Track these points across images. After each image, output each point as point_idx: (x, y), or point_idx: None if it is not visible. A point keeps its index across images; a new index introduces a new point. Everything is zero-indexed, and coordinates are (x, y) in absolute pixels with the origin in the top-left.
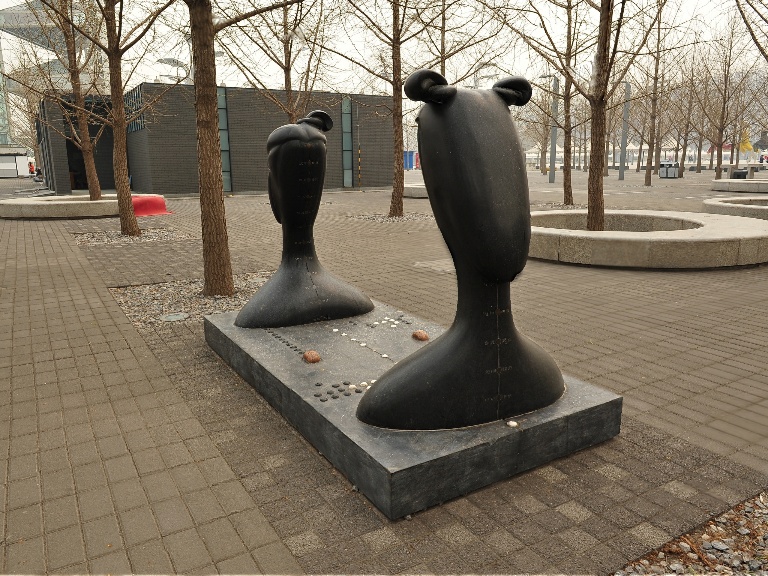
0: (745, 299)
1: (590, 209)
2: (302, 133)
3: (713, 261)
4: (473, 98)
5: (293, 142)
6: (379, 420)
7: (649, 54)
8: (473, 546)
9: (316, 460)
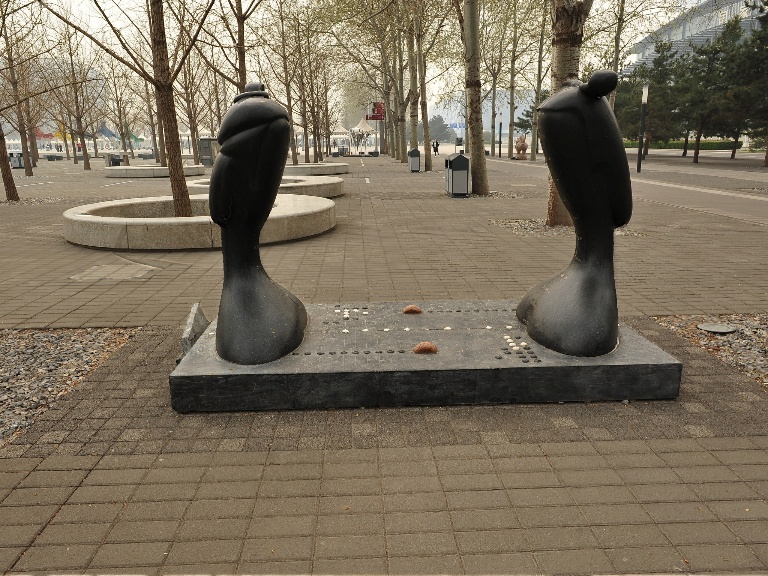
0: None
1: (178, 196)
2: (282, 110)
3: (321, 227)
4: None
5: (280, 121)
6: (605, 349)
7: (228, 48)
8: (706, 386)
9: (570, 407)
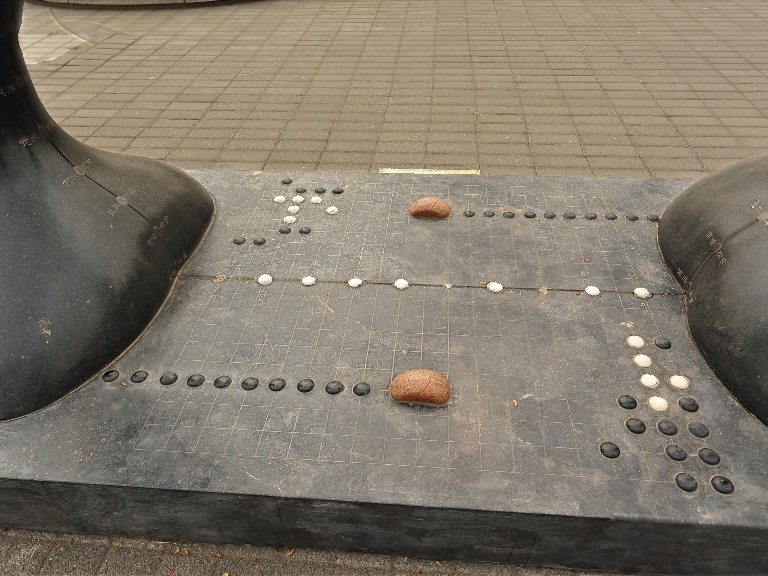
0: (452, 7)
1: None
2: None
3: None
4: None
5: None
6: None
7: None
8: None
9: None
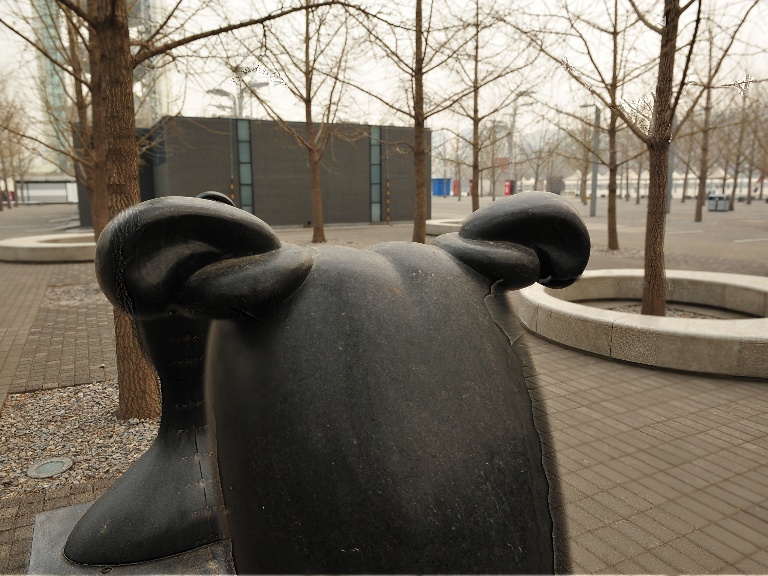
0: None
1: (650, 278)
2: None
3: None
4: (365, 292)
5: None
6: None
7: (734, 85)
8: None
9: None
